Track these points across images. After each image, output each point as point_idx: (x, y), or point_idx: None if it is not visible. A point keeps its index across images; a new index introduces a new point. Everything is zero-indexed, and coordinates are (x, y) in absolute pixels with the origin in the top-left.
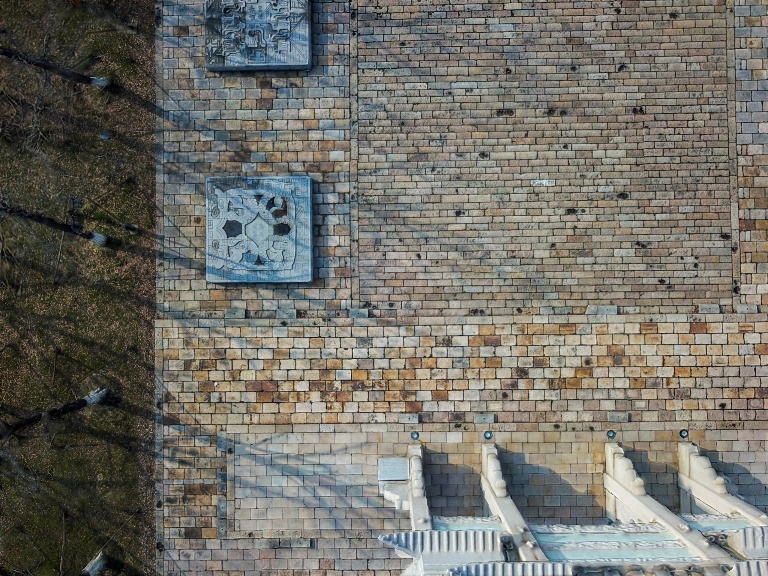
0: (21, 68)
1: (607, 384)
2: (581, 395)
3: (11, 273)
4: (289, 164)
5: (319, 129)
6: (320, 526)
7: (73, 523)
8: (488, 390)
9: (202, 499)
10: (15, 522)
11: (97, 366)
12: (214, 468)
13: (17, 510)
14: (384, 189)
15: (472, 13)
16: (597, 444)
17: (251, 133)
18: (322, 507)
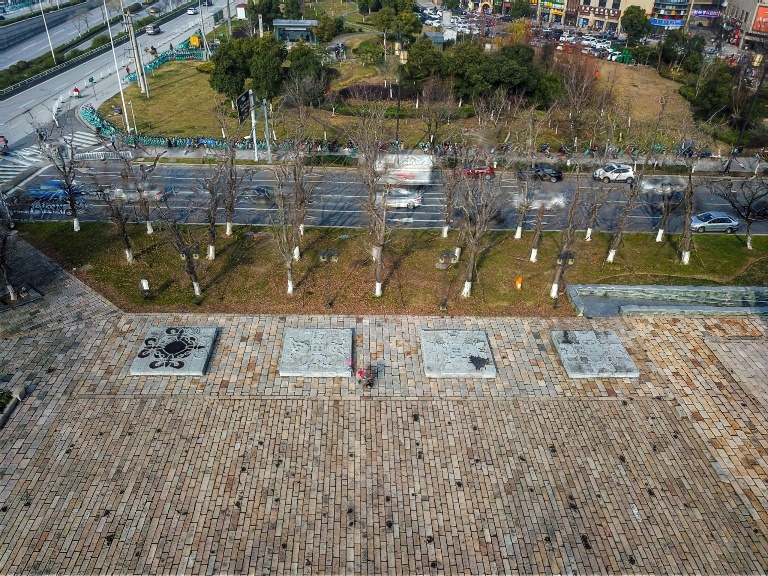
0: None
1: None
2: None
3: None
4: None
5: None
6: None
7: None
8: None
9: None
10: None
11: None
12: None
13: None
14: None
15: (500, 571)
16: None
17: None
18: None
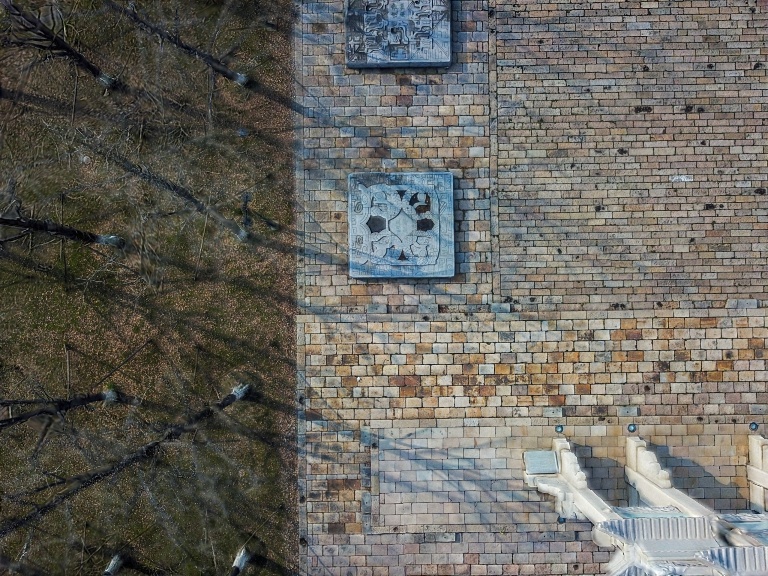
0: (162, 65)
1: (748, 377)
2: (722, 388)
3: (152, 269)
4: (429, 160)
5: (459, 125)
6: (465, 520)
7: (215, 520)
8: (630, 384)
9: (345, 494)
10: (157, 519)
11: (239, 362)
12: (357, 463)
13: (159, 507)
14: (524, 185)
15: (609, 11)
16: (740, 436)
17: (391, 129)
18: (467, 501)
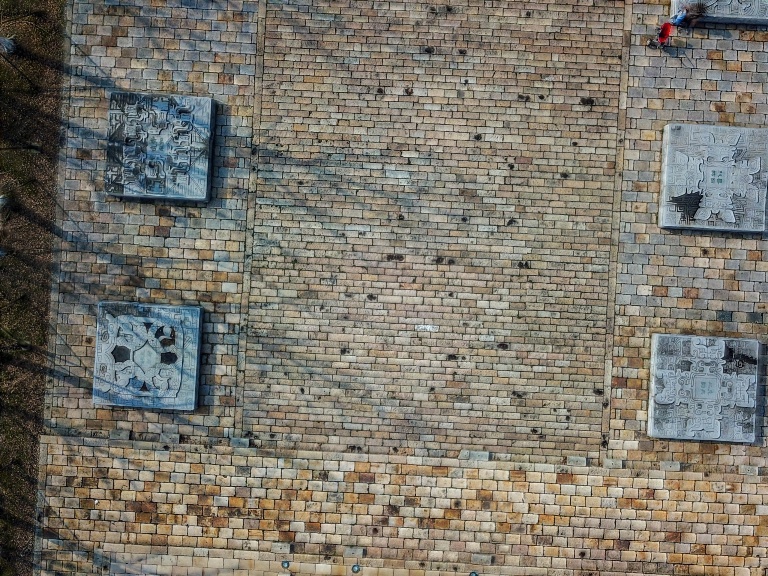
0: None
1: (474, 527)
2: (448, 536)
3: None
4: (182, 292)
5: (214, 260)
6: None
7: None
8: (359, 525)
9: None
10: None
11: None
12: None
13: None
14: (273, 323)
15: (370, 157)
16: None
17: (147, 259)
18: None
